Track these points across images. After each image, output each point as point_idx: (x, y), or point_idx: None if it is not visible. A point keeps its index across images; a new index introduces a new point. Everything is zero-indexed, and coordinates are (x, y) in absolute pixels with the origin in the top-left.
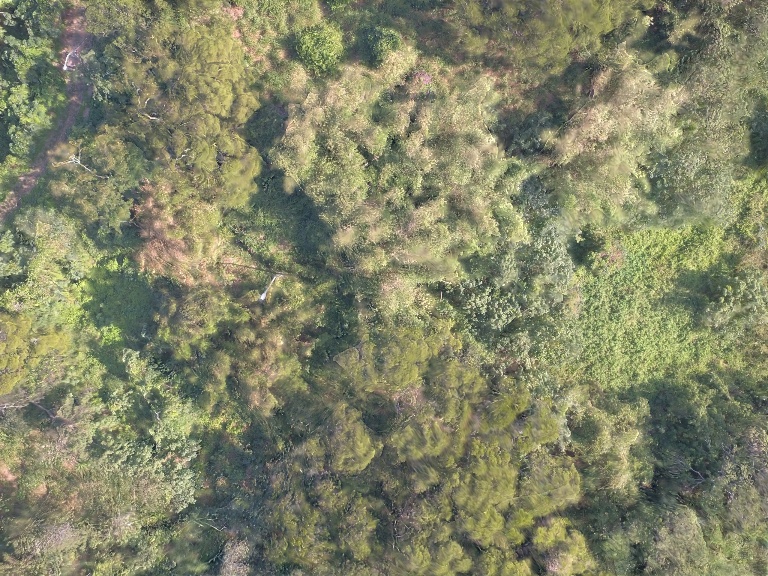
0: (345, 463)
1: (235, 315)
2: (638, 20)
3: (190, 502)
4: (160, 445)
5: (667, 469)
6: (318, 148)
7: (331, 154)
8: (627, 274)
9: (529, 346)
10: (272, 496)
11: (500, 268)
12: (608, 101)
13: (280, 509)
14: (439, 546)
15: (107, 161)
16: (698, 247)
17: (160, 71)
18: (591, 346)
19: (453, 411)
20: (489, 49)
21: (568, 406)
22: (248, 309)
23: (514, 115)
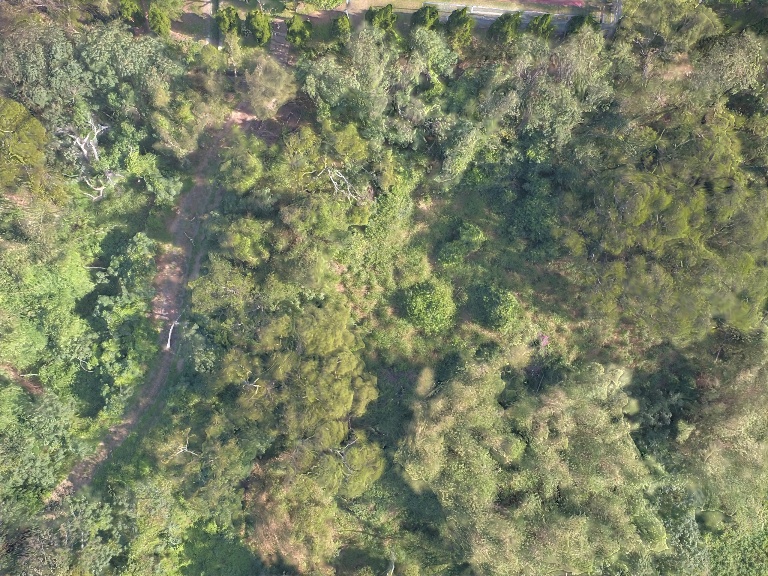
0: None
1: None
2: None
3: None
4: None
5: None
6: (447, 451)
7: (462, 460)
8: (755, 538)
9: None
10: None
11: (637, 567)
12: (755, 400)
13: None
14: None
15: (220, 458)
16: None
17: (261, 328)
18: None
19: None
20: None
21: None
22: None
23: (636, 375)
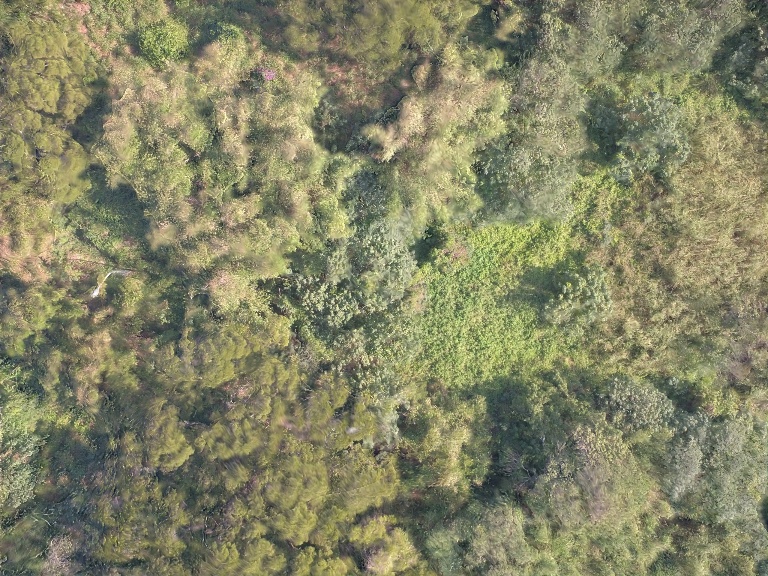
0: (161, 459)
1: (68, 311)
2: (486, 14)
3: (29, 497)
4: (1, 440)
5: (501, 467)
6: (140, 144)
7: (152, 150)
8: (474, 271)
9: (363, 343)
10: (99, 492)
11: (327, 265)
12: (429, 97)
13: (104, 505)
14: (247, 543)
15: None
16: (544, 244)
17: (8, 67)
18: (436, 343)
19: (264, 408)
20: (335, 44)
21: (394, 403)
22: (85, 305)
23: (359, 111)
